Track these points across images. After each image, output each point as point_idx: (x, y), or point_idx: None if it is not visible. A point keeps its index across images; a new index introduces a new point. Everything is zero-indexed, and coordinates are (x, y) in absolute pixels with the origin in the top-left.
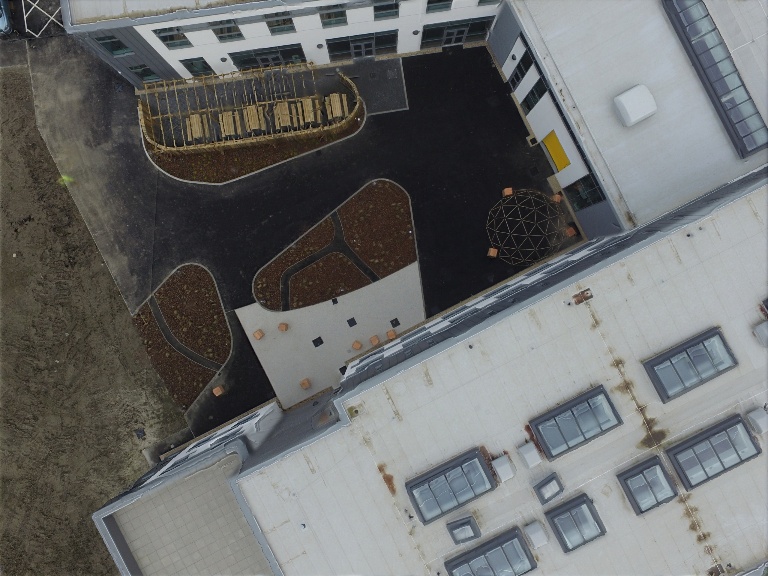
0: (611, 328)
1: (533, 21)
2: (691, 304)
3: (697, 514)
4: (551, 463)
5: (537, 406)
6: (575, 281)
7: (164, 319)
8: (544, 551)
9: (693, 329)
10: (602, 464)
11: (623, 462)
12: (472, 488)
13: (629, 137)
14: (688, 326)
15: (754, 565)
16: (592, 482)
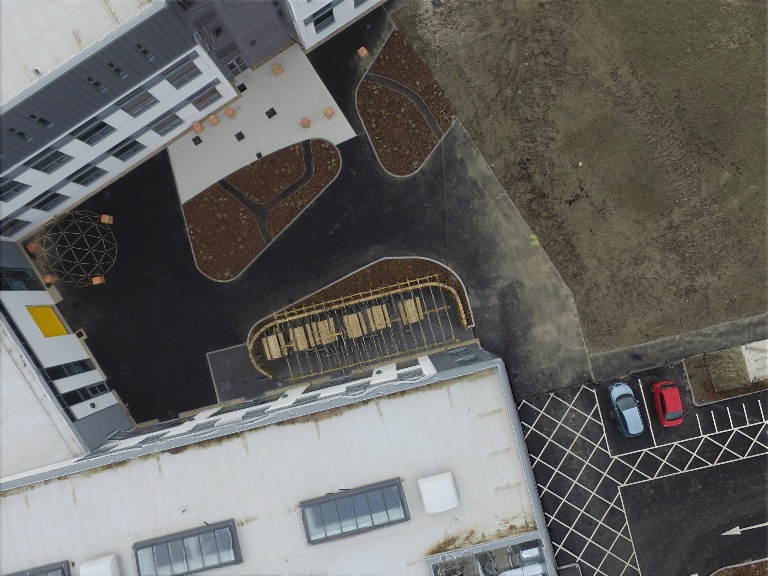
0: None
1: (59, 431)
2: None
3: None
4: None
5: None
6: None
7: (425, 118)
8: None
9: None
10: None
11: None
12: None
13: None
14: None
15: None
16: None
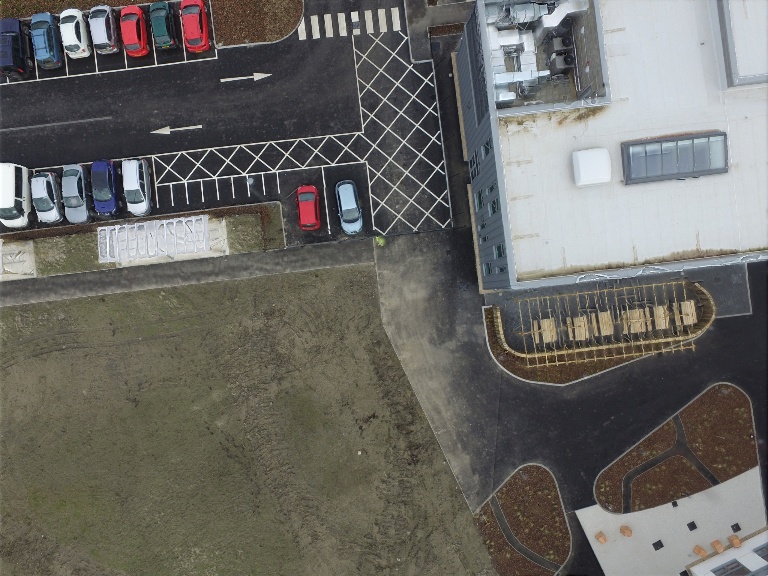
0: None
1: None
2: None
3: None
4: None
5: None
6: None
7: (505, 519)
8: None
9: None
10: None
11: None
12: None
13: None
14: None
15: None
16: None
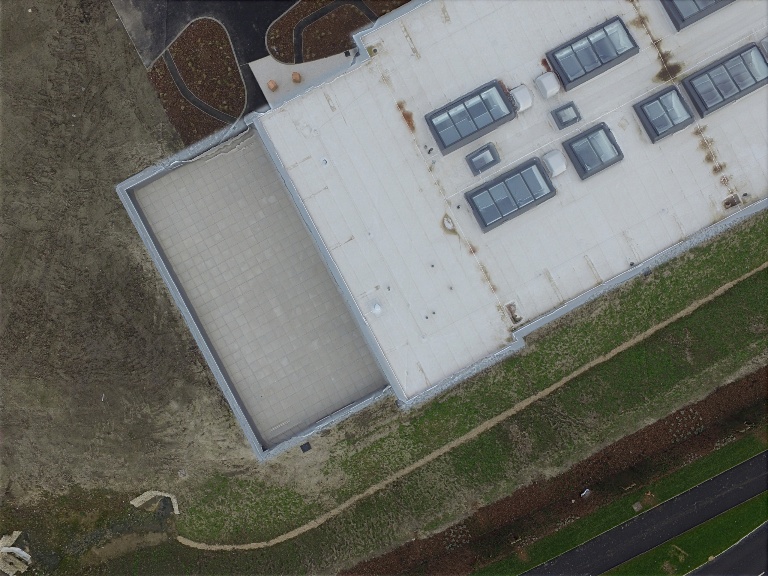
0: None
1: None
2: None
3: (713, 146)
4: (568, 95)
5: (553, 40)
6: None
7: (179, 73)
8: (562, 183)
9: None
10: (618, 97)
11: (639, 95)
12: (491, 113)
13: None
14: None
15: None
16: (609, 115)
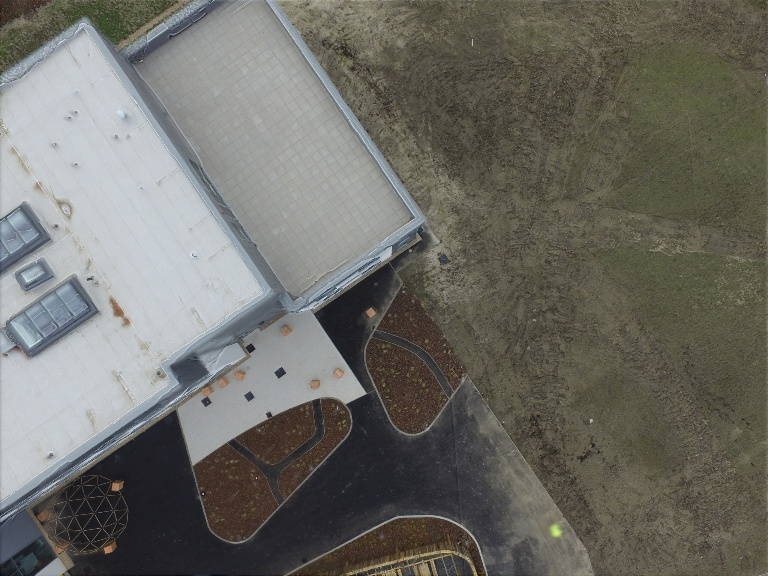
0: None
1: None
2: None
3: None
4: None
5: None
6: None
7: (435, 376)
8: None
9: None
10: None
11: None
12: (28, 320)
13: None
14: None
15: None
16: None
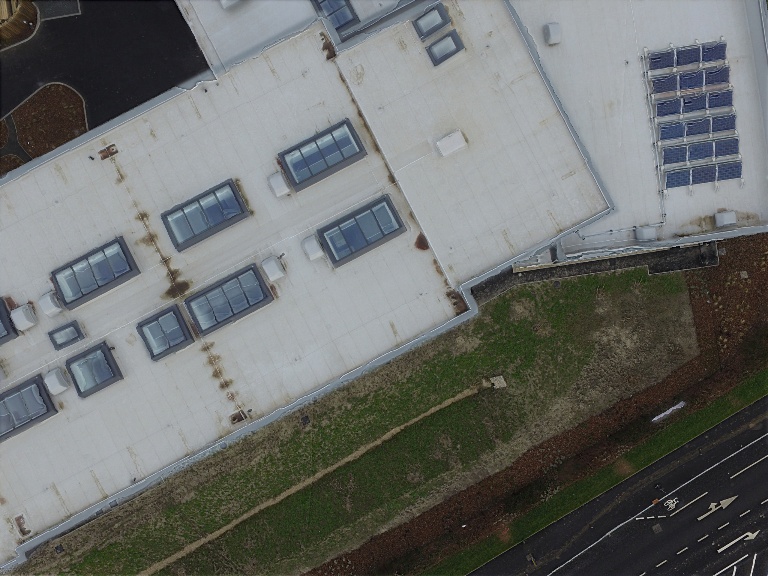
0: (135, 182)
1: None
2: (211, 158)
3: (220, 362)
4: (74, 312)
5: (62, 258)
6: (94, 135)
7: None
8: (69, 398)
9: (213, 182)
10: (127, 314)
11: (147, 312)
12: None
13: (232, 21)
14: (208, 179)
15: (273, 410)
16: (117, 331)
